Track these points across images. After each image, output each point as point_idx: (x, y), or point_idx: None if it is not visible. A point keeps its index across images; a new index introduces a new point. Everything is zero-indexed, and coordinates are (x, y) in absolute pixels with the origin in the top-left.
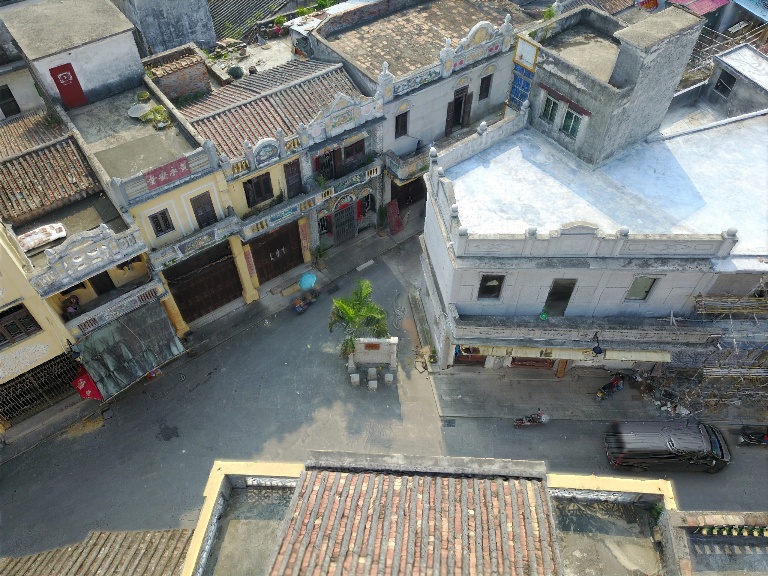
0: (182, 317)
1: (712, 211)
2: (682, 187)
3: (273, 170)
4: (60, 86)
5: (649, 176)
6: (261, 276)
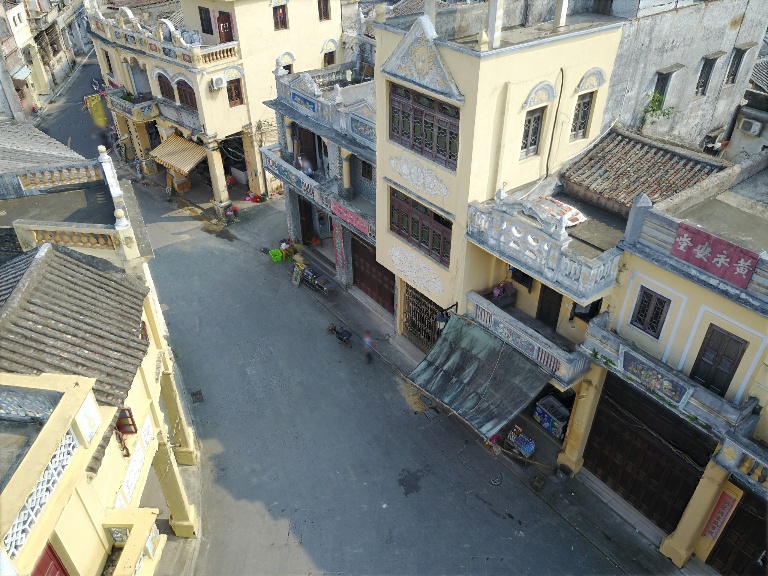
0: (586, 452)
1: None
2: None
3: None
4: None
5: None
6: (721, 556)
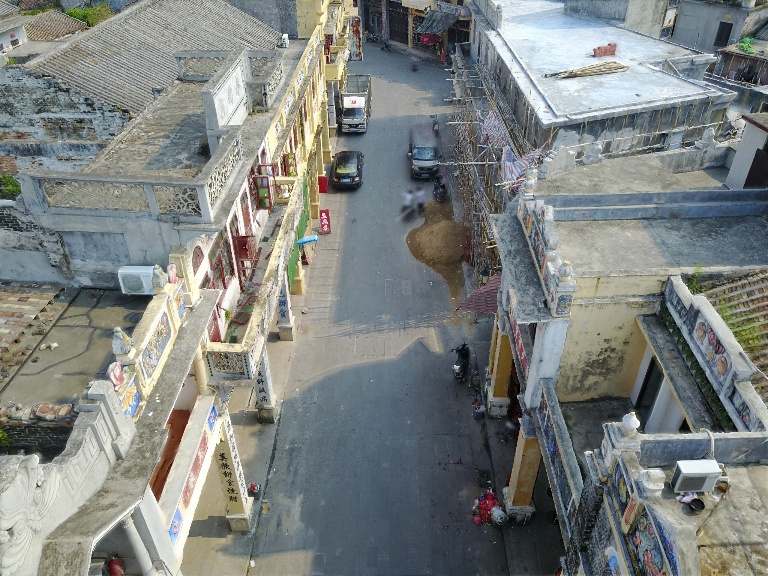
0: None
1: None
2: None
3: None
4: None
5: (567, 22)
6: None
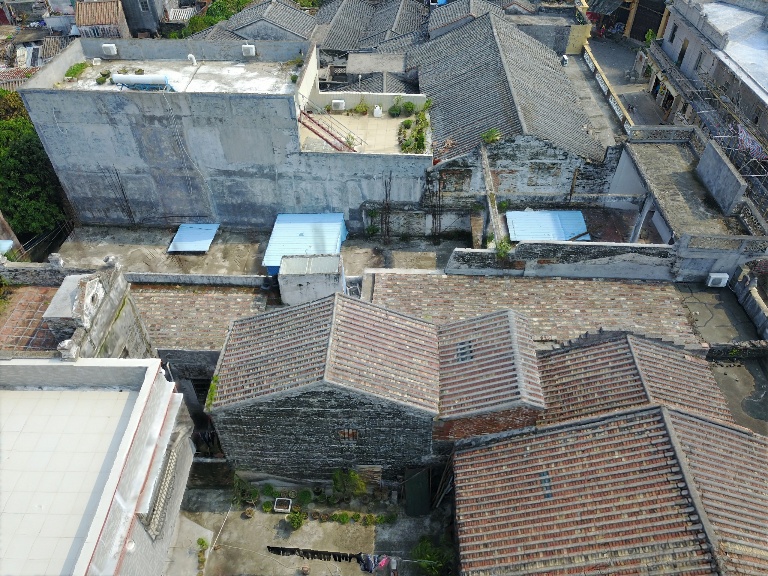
0: (631, 32)
1: (754, 50)
2: (767, 46)
3: None
4: None
5: None
6: None
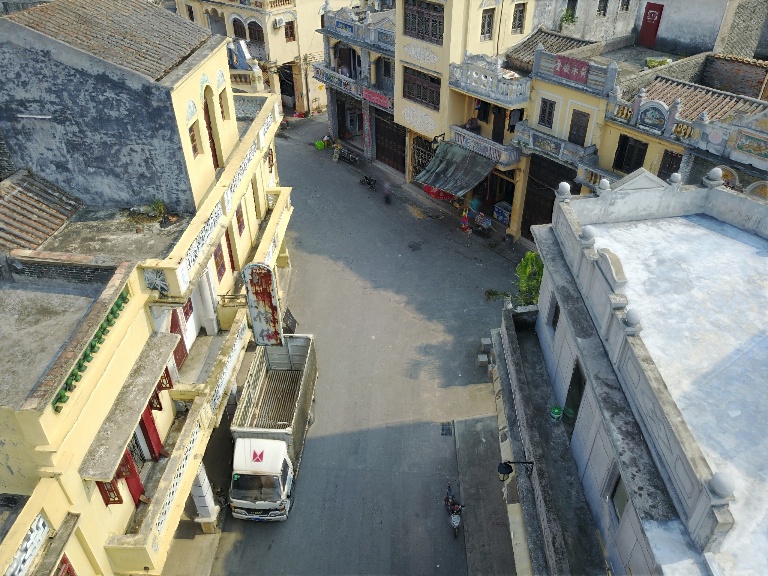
0: (523, 225)
1: None
2: None
3: (653, 146)
4: (645, 21)
5: None
6: None
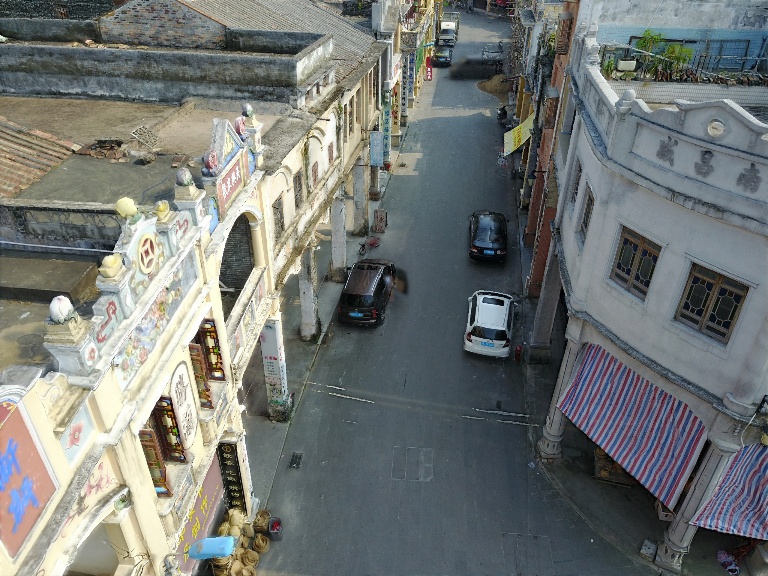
0: None
1: None
2: None
3: None
4: None
5: None
6: None
